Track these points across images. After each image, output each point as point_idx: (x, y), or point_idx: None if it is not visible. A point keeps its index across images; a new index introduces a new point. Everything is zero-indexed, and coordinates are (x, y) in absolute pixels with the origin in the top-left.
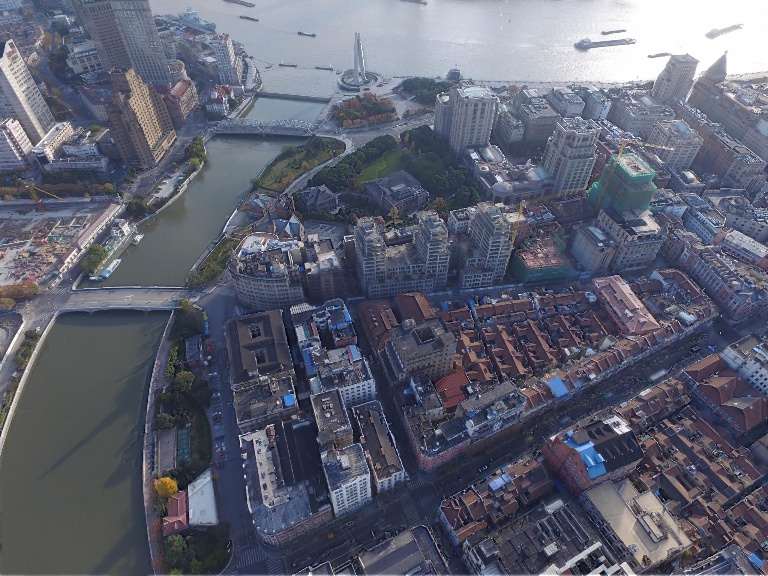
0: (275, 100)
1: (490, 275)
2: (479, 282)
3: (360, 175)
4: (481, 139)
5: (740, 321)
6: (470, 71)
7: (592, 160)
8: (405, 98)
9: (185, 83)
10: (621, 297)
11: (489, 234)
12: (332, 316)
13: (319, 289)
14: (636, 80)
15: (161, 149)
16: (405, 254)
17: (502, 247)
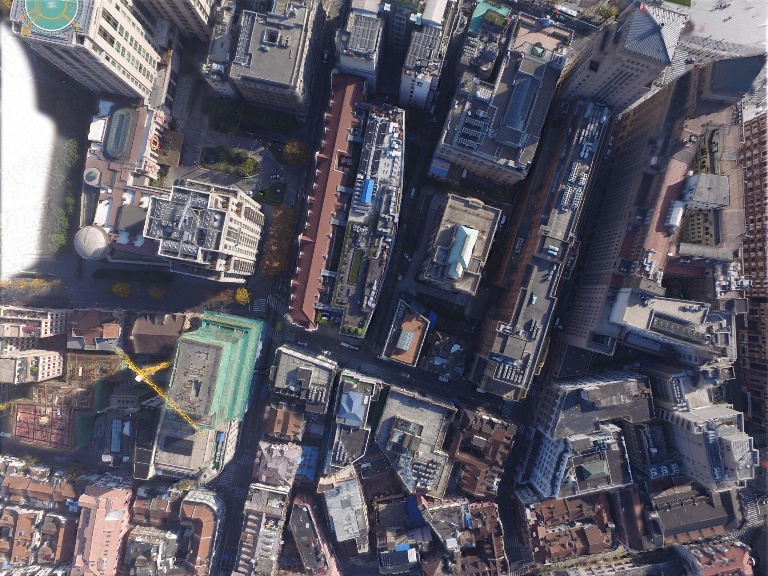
0: None
1: None
2: None
3: None
4: (121, 90)
5: None
6: None
7: None
8: None
9: None
10: (87, 537)
11: None
12: None
13: None
14: None
15: None
16: None
17: None
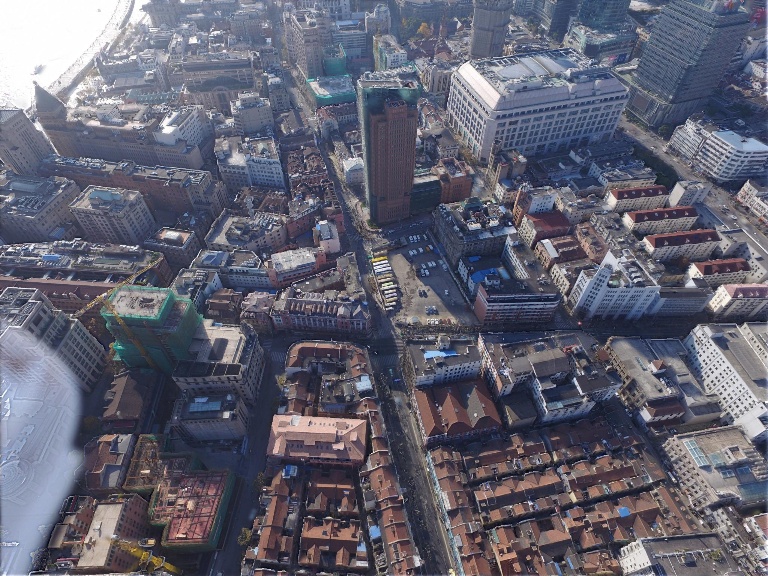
0: None
1: None
2: None
3: None
4: None
5: None
6: None
7: (75, 326)
8: None
9: None
10: (313, 440)
11: None
12: None
13: None
14: None
15: None
16: None
17: None
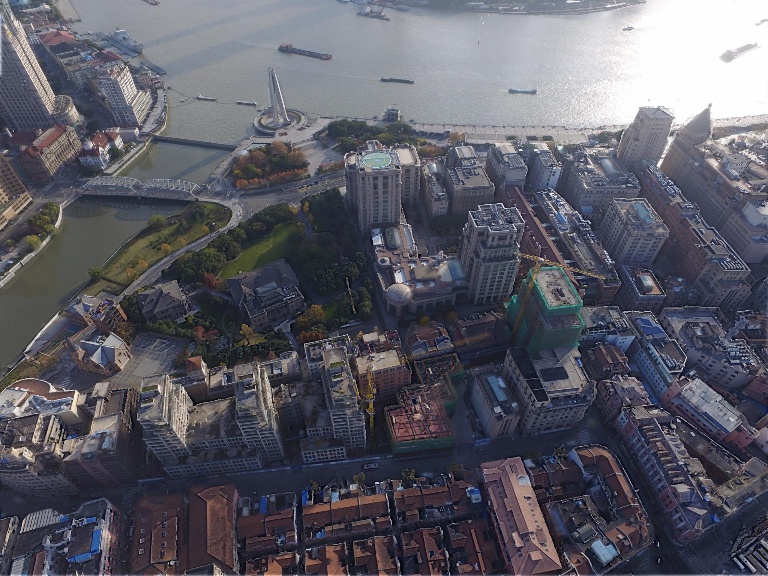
0: (176, 146)
1: (340, 449)
2: (327, 456)
3: (235, 260)
4: (389, 216)
5: (690, 541)
6: (411, 111)
7: (514, 263)
8: (326, 146)
9: (59, 129)
10: (512, 507)
11: (328, 404)
12: (74, 539)
13: (88, 475)
14: (609, 125)
15: (0, 220)
16: (223, 417)
17: (350, 419)
